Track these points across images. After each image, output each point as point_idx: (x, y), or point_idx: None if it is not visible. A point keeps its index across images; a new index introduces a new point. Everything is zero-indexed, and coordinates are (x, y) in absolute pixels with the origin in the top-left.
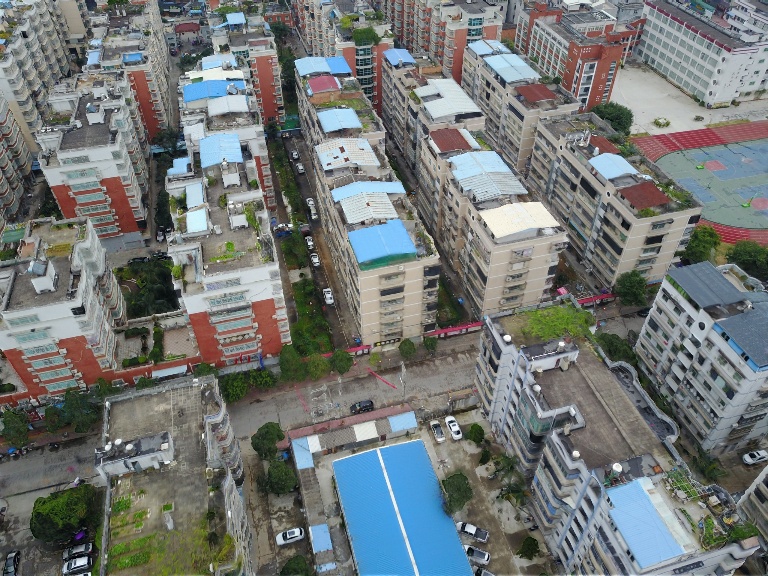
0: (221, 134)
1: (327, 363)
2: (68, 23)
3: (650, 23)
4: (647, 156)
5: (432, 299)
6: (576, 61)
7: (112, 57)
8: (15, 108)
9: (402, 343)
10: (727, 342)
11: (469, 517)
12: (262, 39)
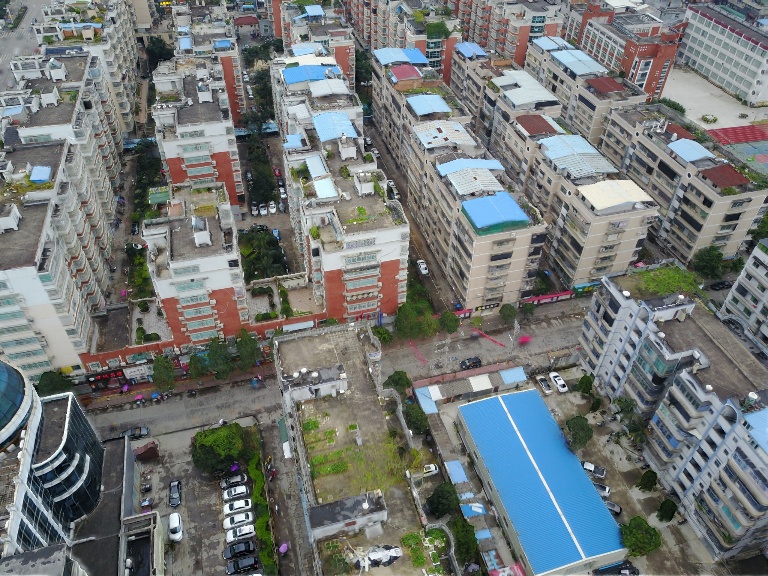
0: (331, 113)
1: (438, 323)
2: (136, 13)
3: (692, 27)
4: (719, 143)
5: (534, 266)
6: (633, 59)
7: (203, 43)
8: (110, 89)
9: (504, 307)
10: None
11: (584, 457)
12: (341, 30)
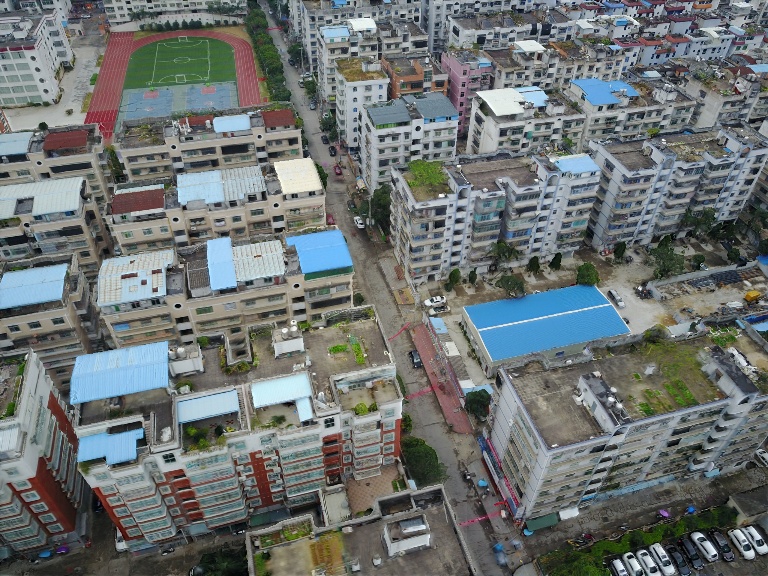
0: (73, 373)
1: None
2: None
3: None
4: (215, 109)
5: None
6: None
7: None
8: None
9: None
10: (435, 122)
11: None
12: None
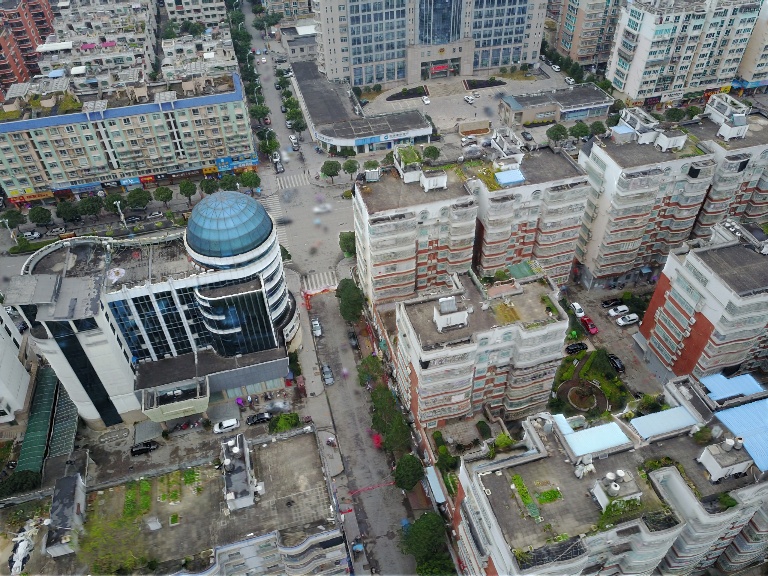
0: None
1: None
2: None
3: None
4: None
5: None
6: None
7: None
8: None
9: None
10: None
11: None
12: None
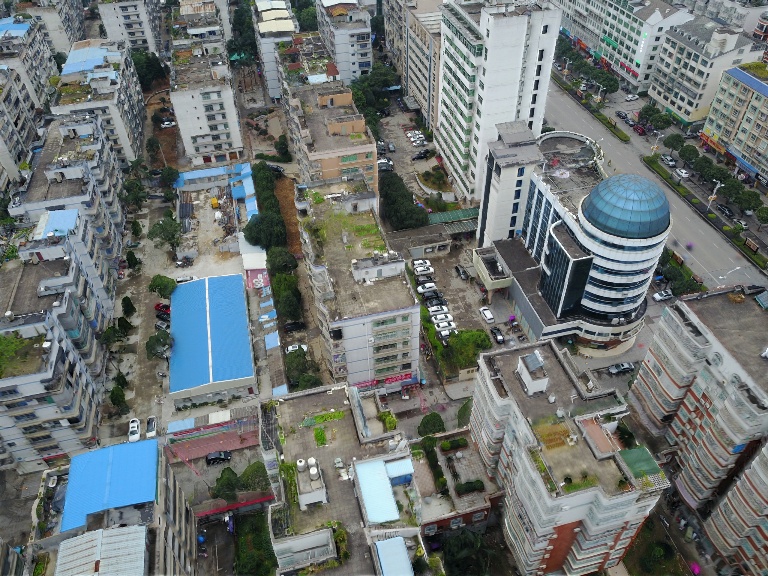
0: None
1: None
2: None
3: None
4: None
5: None
6: None
7: None
8: None
9: None
10: None
11: (157, 363)
12: None
